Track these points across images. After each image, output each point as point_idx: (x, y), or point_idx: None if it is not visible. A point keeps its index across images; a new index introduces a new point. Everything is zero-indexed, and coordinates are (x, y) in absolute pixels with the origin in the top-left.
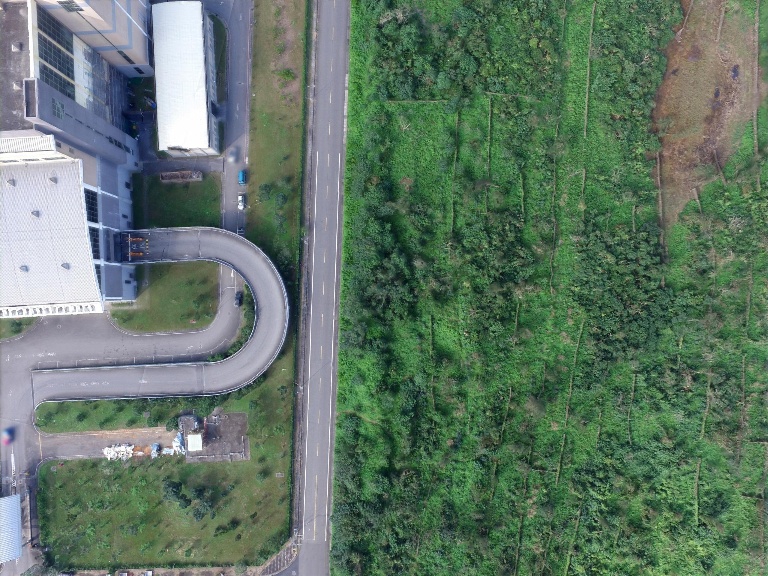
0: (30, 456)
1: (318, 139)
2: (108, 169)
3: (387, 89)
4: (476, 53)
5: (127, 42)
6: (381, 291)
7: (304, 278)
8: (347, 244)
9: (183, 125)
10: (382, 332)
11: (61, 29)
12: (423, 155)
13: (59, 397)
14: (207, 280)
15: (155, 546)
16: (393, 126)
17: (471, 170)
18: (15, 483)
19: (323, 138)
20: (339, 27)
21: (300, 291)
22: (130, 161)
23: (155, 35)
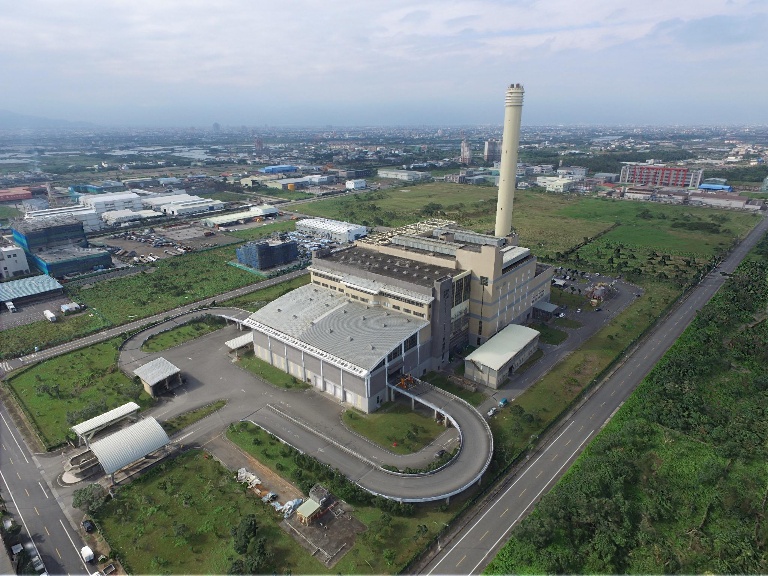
0: (199, 440)
1: (579, 416)
2: (428, 350)
3: (658, 416)
4: (760, 434)
5: (490, 317)
6: (588, 515)
7: (509, 476)
8: (568, 478)
9: (489, 356)
10: (568, 558)
11: (468, 291)
12: (681, 468)
13: (261, 425)
14: (428, 432)
15: (165, 569)
16: (655, 438)
17: (739, 499)
18: (168, 446)
19: (583, 418)
20: (628, 383)
21: (499, 481)
22: (439, 362)
23: (503, 330)
